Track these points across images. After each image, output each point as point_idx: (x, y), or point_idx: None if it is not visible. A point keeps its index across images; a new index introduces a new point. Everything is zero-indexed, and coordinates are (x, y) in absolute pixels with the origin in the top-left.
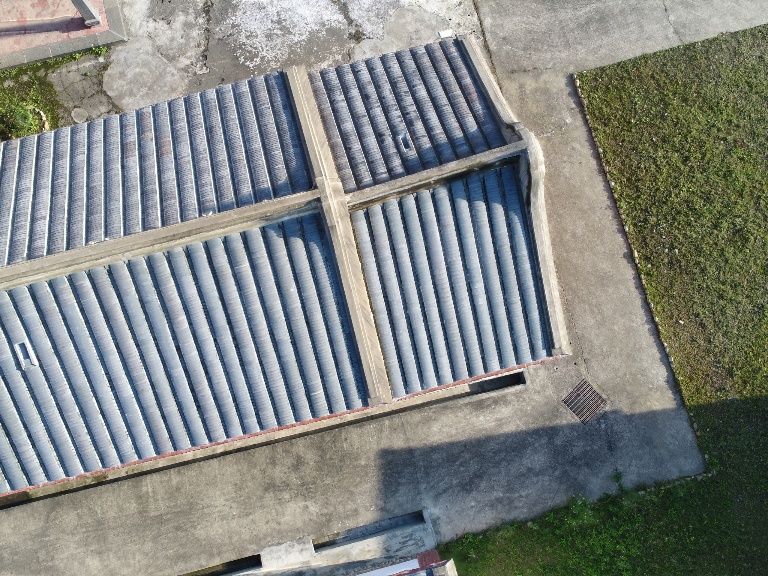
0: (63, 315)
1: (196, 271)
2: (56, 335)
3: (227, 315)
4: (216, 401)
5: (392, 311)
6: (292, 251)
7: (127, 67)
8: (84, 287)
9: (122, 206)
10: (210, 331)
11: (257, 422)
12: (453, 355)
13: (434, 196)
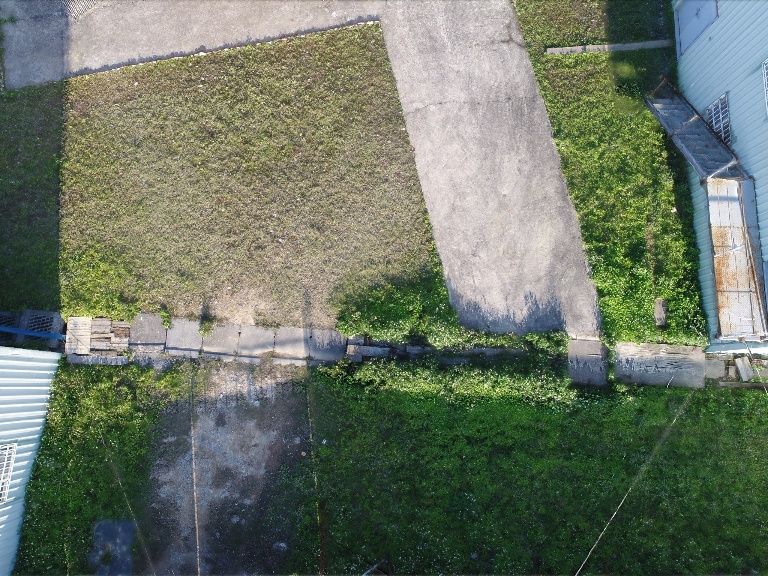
0: None
1: None
2: None
3: None
4: None
5: None
6: None
7: None
8: None
9: None
10: None
11: None
12: None
13: None
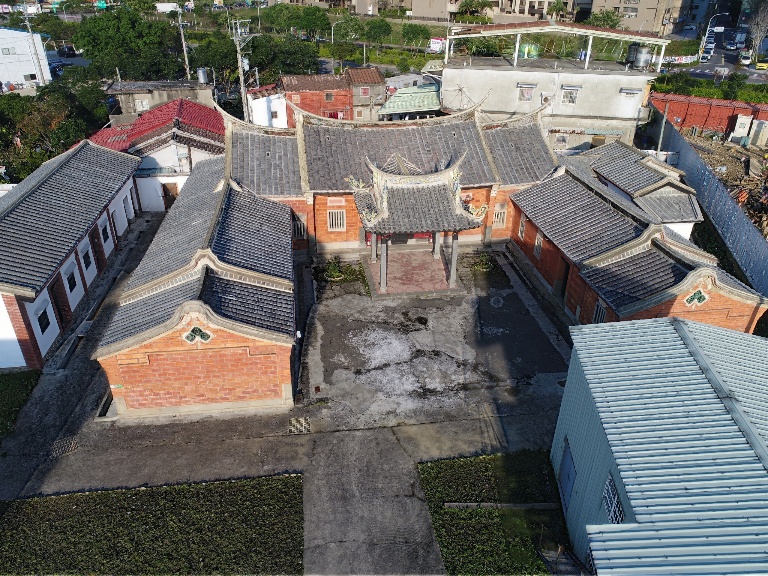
0: None
1: None
2: None
3: None
4: None
5: None
6: None
7: None
8: None
9: None
10: None
11: None
12: None
13: None
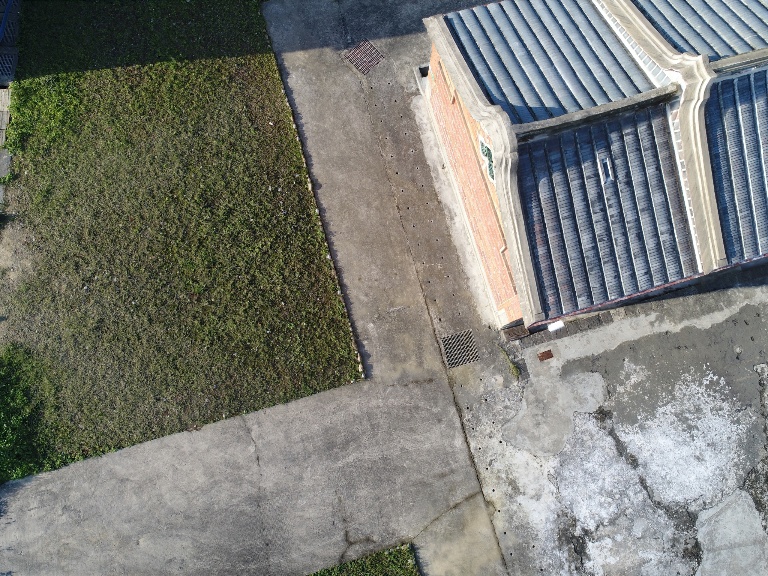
0: None
1: None
2: None
3: None
4: None
5: (596, 34)
6: (710, 48)
7: None
8: None
9: None
10: (760, 1)
11: None
12: (532, 11)
13: (581, 109)
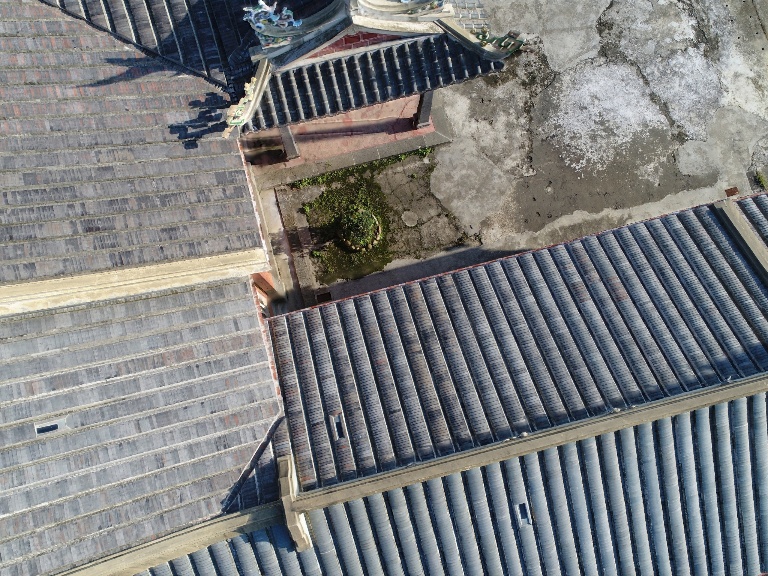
0: (563, 475)
1: (698, 431)
2: (556, 495)
3: (716, 471)
4: (689, 554)
5: None
6: None
7: (453, 169)
8: (592, 449)
9: (602, 358)
10: (697, 487)
11: (724, 573)
12: None
13: None
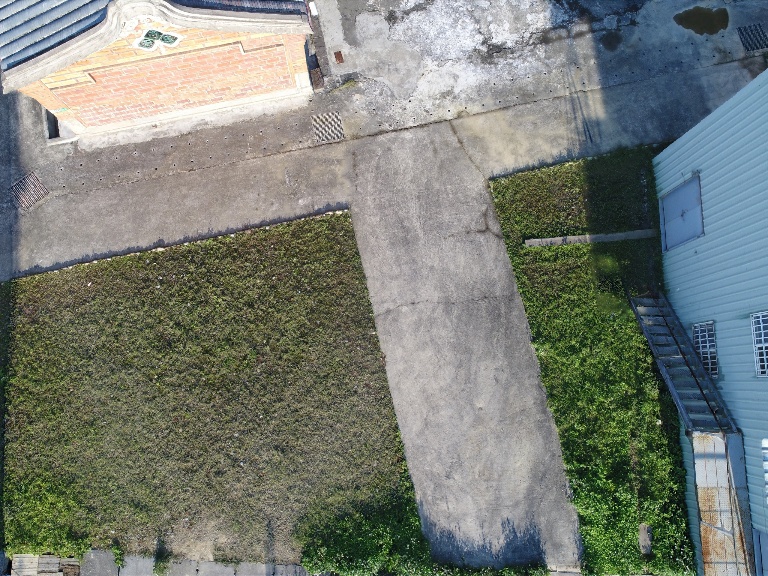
0: None
1: None
2: None
3: None
4: None
5: None
6: None
7: None
8: None
9: None
10: None
11: None
12: None
13: None
